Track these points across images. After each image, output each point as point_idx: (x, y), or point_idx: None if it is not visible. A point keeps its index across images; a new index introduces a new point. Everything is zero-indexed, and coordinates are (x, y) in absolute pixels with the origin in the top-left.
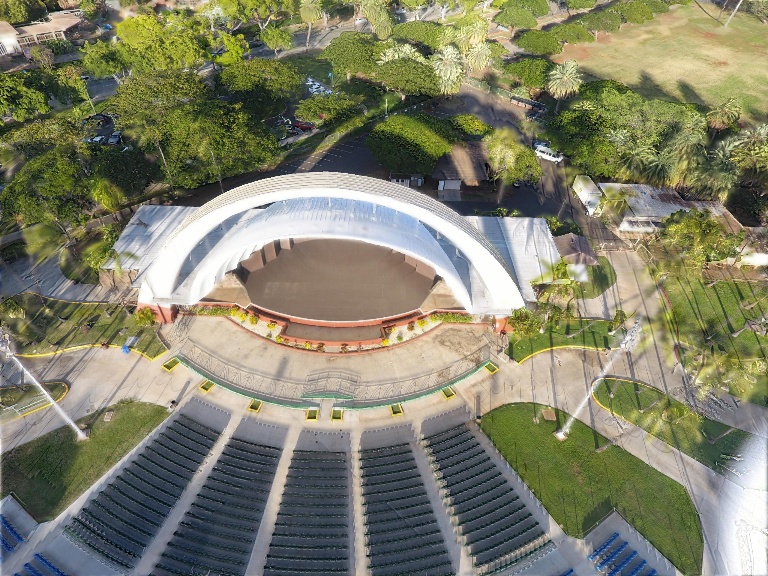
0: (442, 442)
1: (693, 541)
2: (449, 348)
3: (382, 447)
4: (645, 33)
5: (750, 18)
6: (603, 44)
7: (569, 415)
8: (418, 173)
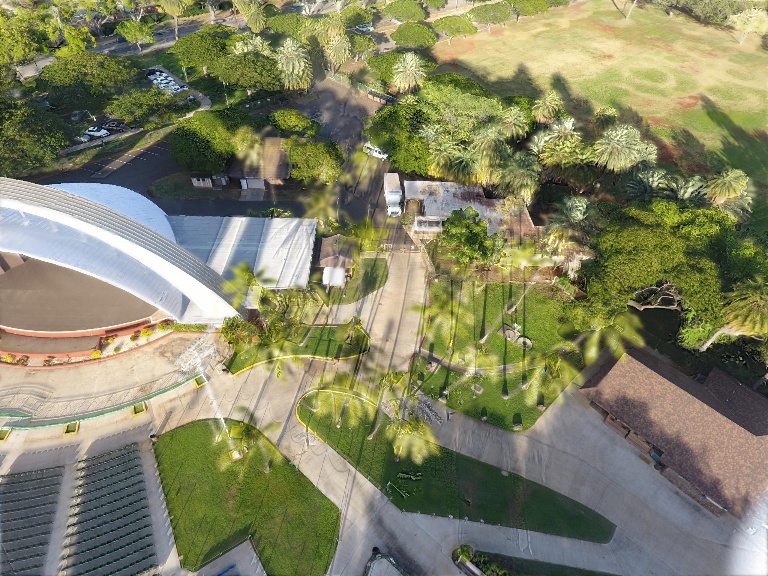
0: (98, 464)
1: (316, 572)
2: (167, 359)
3: (29, 471)
4: (543, 26)
5: (657, 10)
6: (494, 37)
7: (258, 432)
8: (221, 172)
